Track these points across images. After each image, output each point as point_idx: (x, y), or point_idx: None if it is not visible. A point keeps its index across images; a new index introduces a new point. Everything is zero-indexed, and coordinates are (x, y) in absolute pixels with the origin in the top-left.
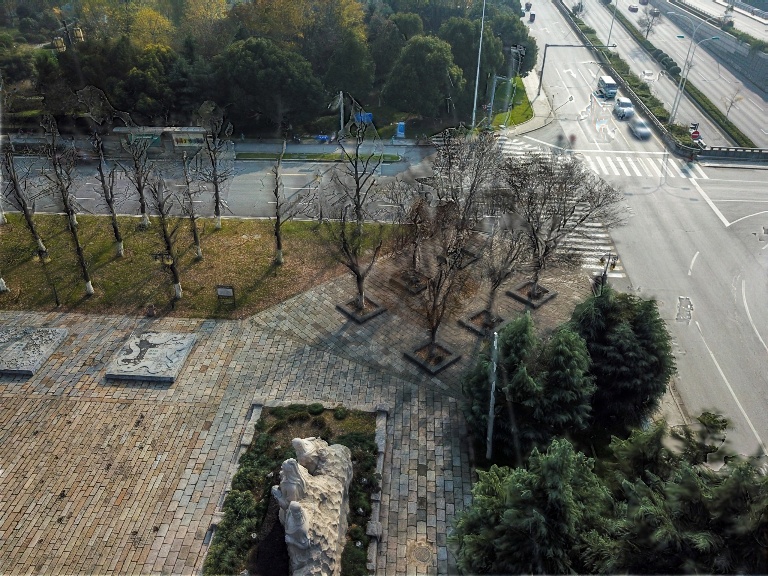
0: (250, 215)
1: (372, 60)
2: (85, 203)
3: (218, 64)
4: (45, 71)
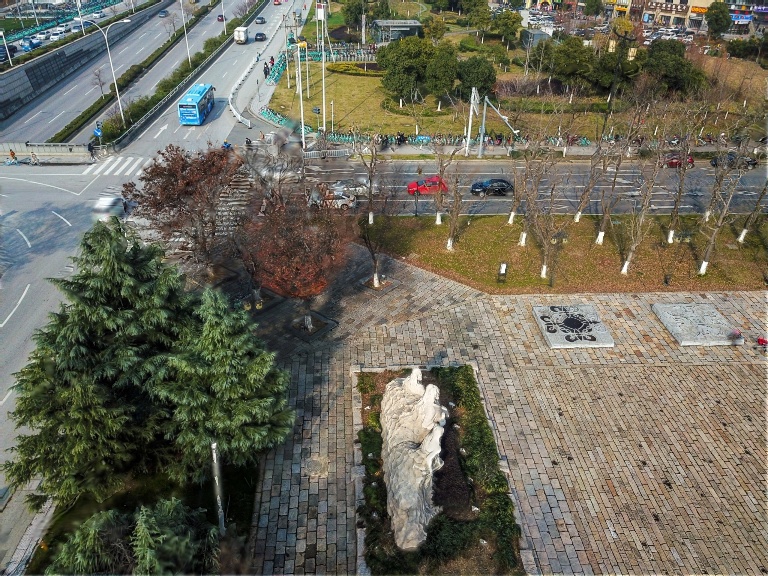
0: None
1: None
2: None
3: None
4: None
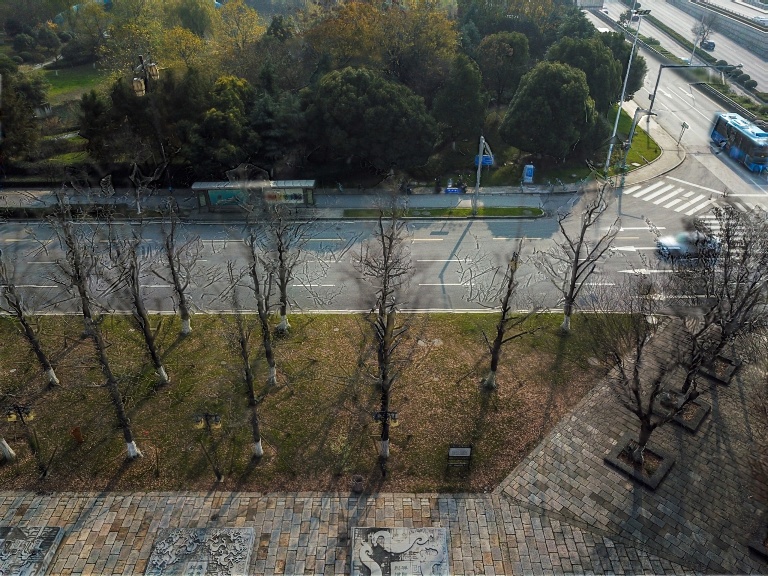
0: (407, 306)
1: (486, 91)
2: None
3: (307, 100)
4: (94, 112)
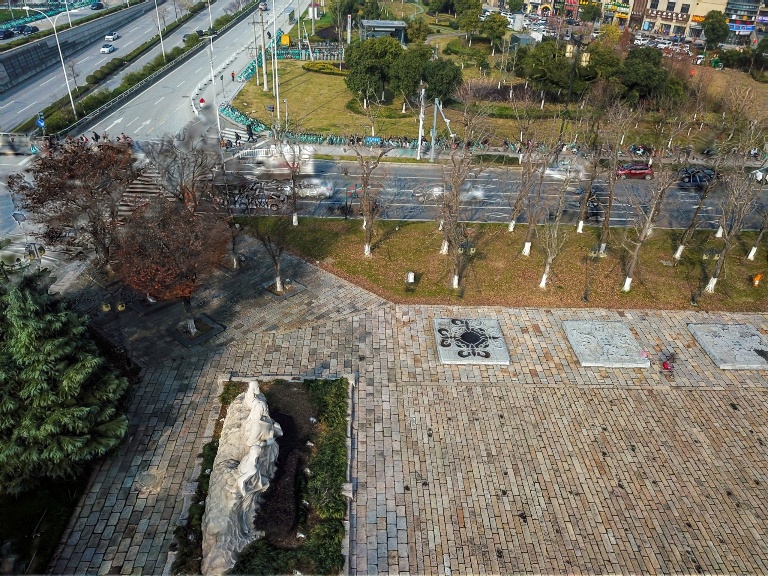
0: None
1: None
2: None
3: None
4: None
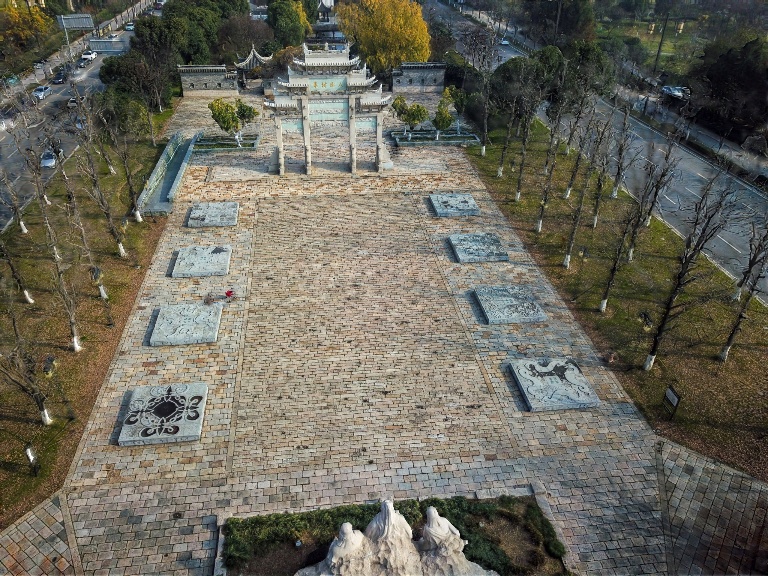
0: None
1: None
2: (727, 250)
3: None
4: None
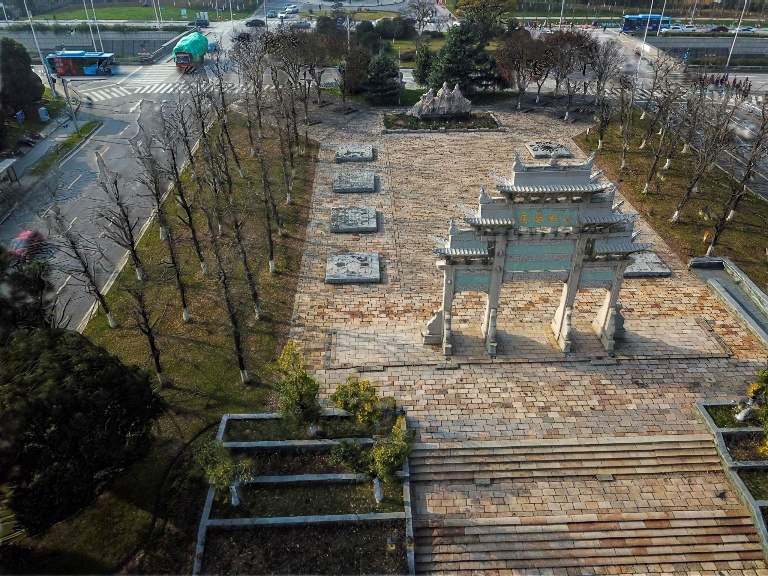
0: None
1: None
2: None
3: None
4: None
